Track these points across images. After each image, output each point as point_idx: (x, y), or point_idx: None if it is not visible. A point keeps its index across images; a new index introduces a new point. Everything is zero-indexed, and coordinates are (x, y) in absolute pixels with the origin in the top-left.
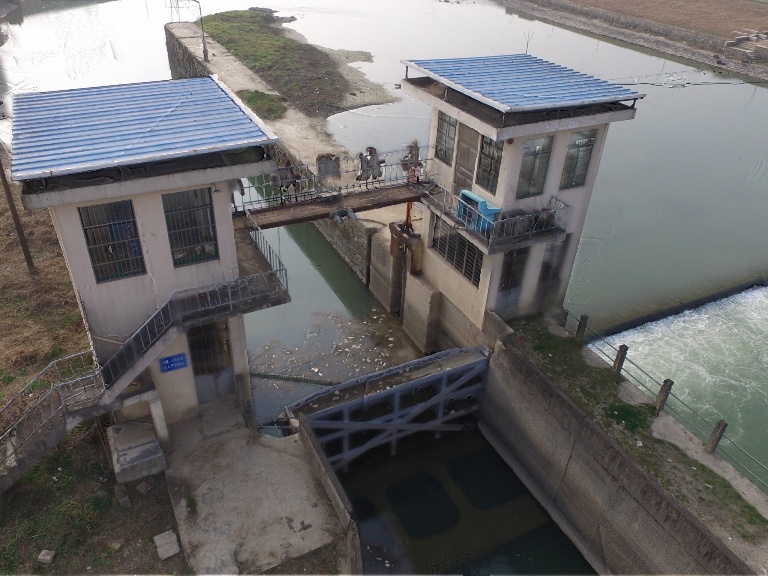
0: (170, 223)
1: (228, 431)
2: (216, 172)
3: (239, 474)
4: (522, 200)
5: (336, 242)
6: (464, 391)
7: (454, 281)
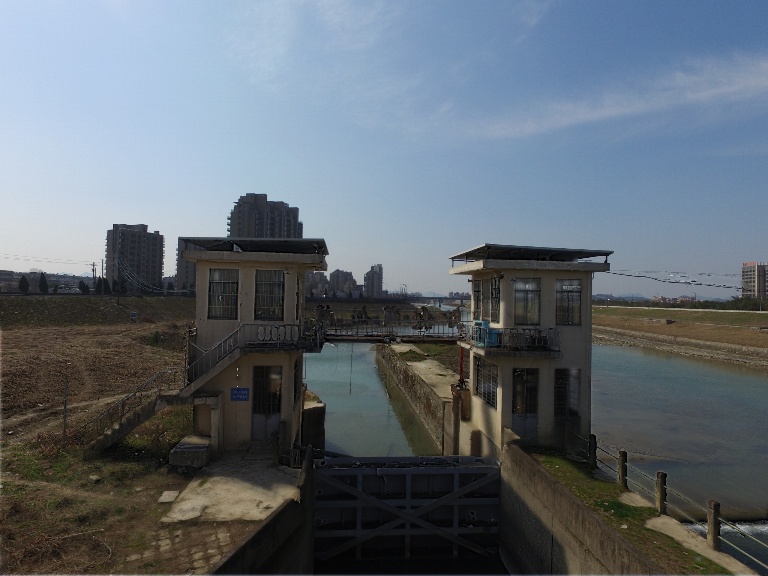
0: (257, 289)
1: (261, 460)
2: (285, 255)
3: (248, 477)
4: (521, 326)
5: (430, 426)
6: (479, 501)
7: (485, 413)
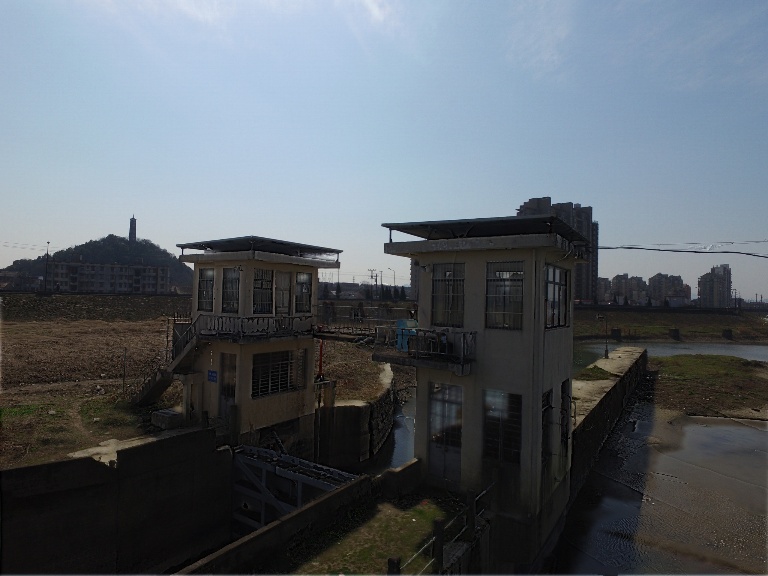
0: (224, 285)
1: None
2: (232, 254)
3: None
4: (439, 328)
5: None
6: None
7: None
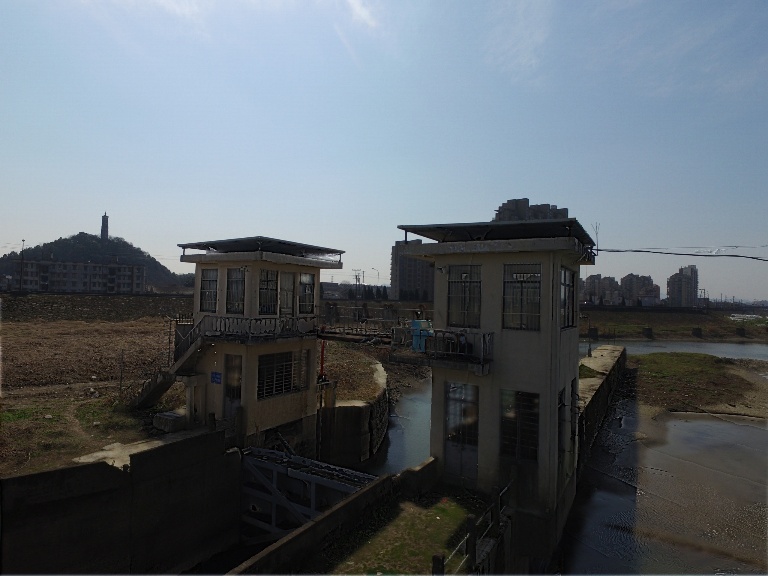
0: (229, 286)
1: None
2: (238, 254)
3: None
4: (455, 329)
5: None
6: None
7: None
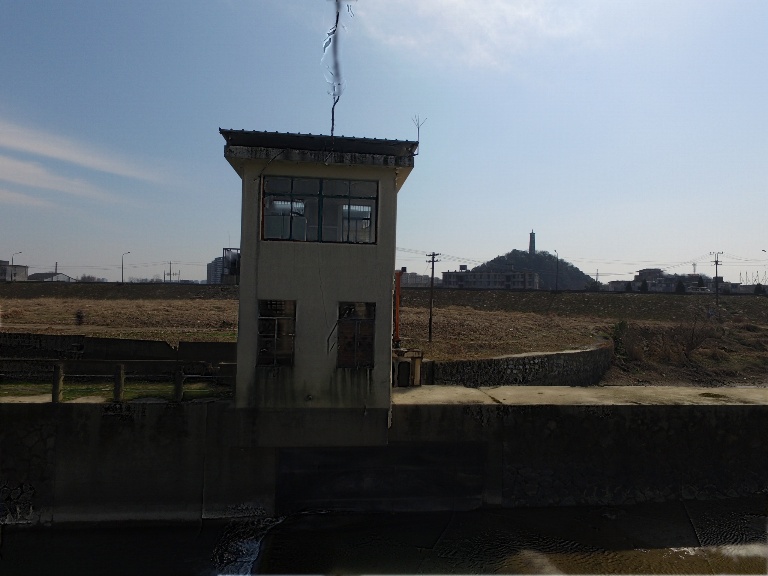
0: None
1: None
2: None
3: None
4: None
5: None
6: None
7: None
